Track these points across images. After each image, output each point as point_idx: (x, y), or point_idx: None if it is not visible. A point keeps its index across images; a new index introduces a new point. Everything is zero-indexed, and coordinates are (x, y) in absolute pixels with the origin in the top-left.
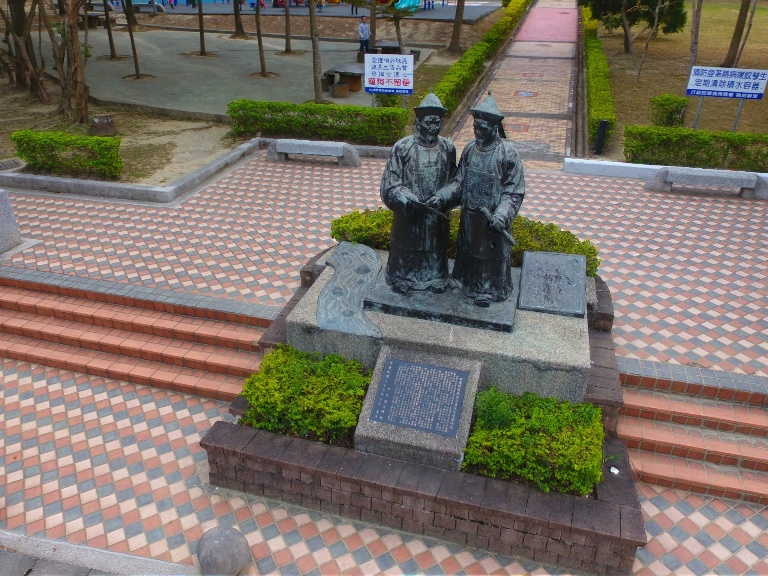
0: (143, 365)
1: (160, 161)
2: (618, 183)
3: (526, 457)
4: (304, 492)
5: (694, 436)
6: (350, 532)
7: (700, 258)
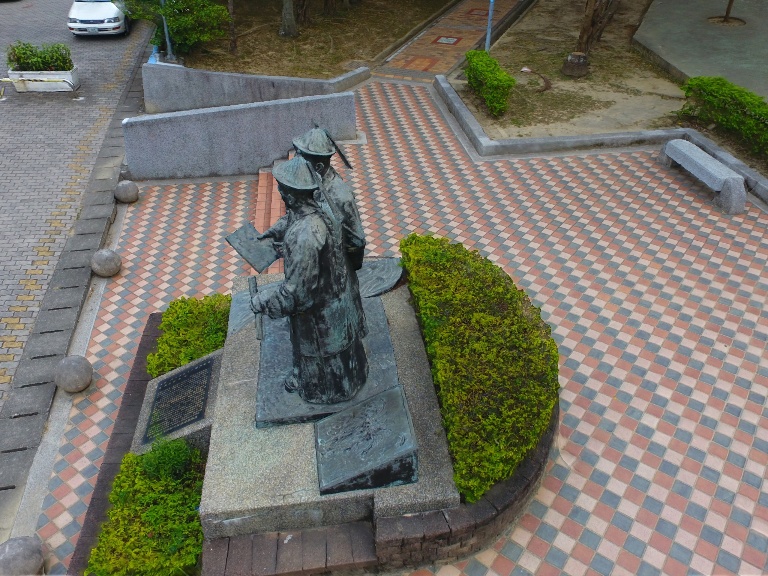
0: None
1: (560, 116)
2: None
3: None
4: None
5: None
6: None
7: None
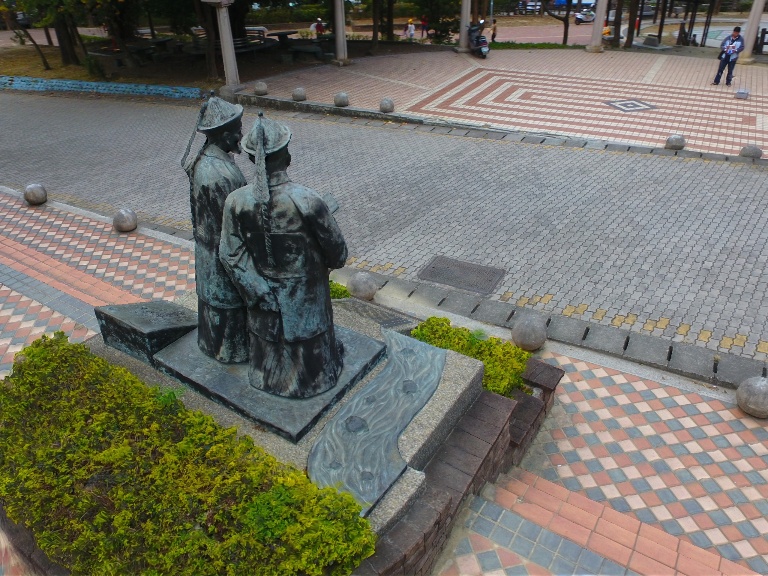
0: None
1: None
2: None
3: None
4: None
5: None
6: None
7: None
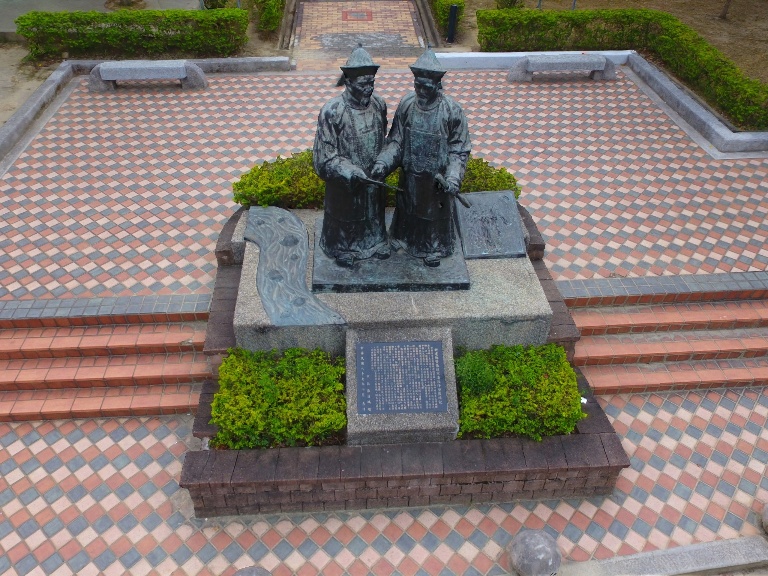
0: (54, 397)
1: None
2: (482, 76)
3: (517, 415)
4: (305, 500)
5: (627, 344)
6: (361, 524)
7: (581, 156)
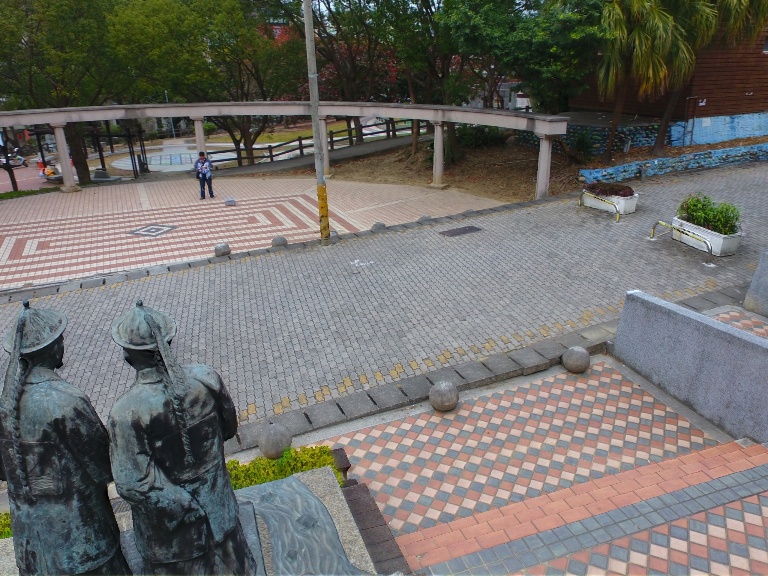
0: None
1: None
2: None
3: None
4: None
5: None
6: None
7: None
